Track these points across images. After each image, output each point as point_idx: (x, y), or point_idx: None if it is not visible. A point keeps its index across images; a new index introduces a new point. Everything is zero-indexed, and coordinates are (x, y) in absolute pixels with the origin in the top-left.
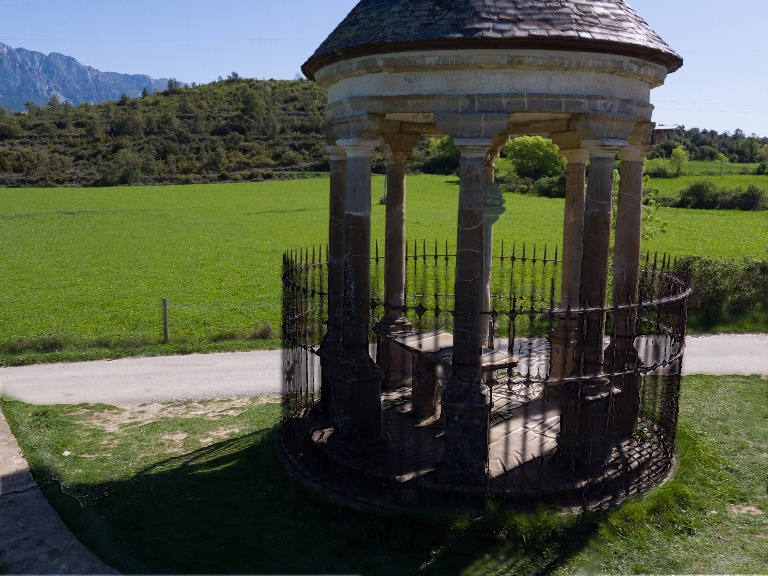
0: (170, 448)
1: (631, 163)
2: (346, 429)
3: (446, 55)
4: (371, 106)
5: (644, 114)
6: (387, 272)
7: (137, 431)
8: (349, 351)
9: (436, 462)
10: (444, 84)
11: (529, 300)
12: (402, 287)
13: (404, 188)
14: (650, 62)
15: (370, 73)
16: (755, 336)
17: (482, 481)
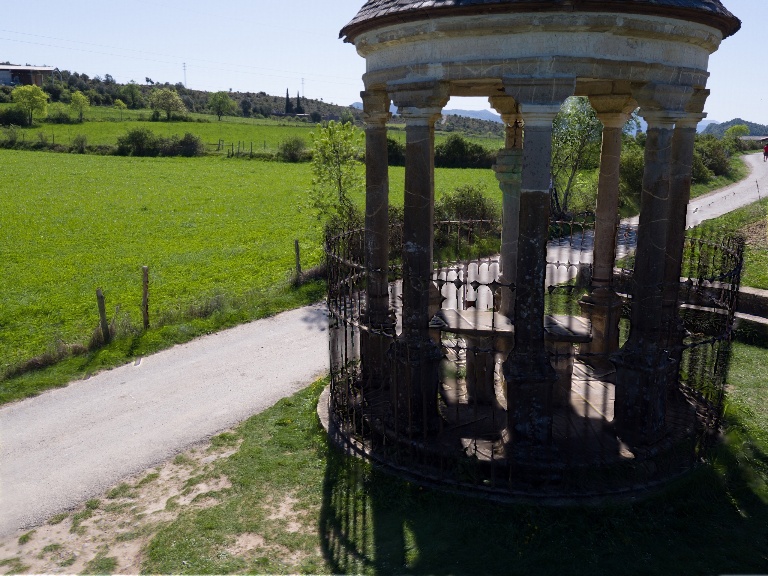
0: (283, 559)
1: (619, 130)
2: (543, 431)
3: (682, 25)
4: (587, 69)
5: None
6: (377, 255)
7: (175, 567)
8: (538, 346)
9: (605, 431)
10: (661, 54)
11: (437, 263)
12: None
13: None
14: None
15: (590, 31)
16: (459, 266)
17: (671, 430)
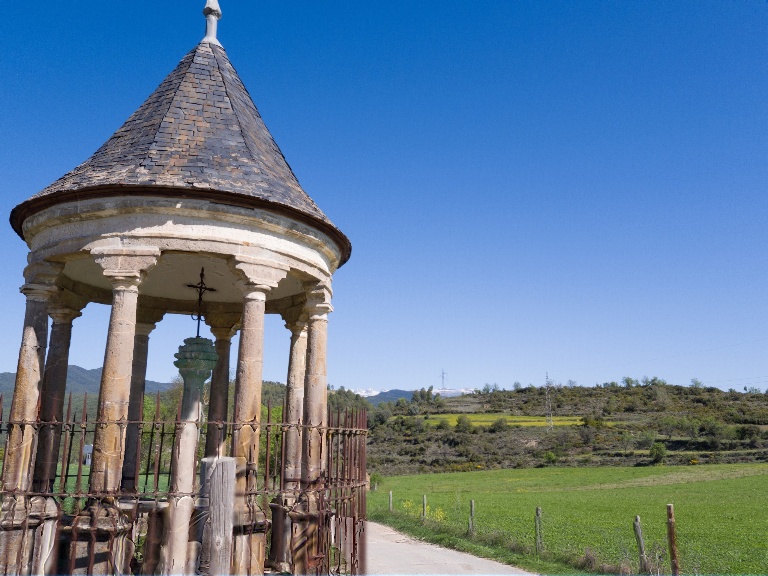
0: None
1: None
2: None
3: None
4: None
5: (57, 252)
6: None
7: None
8: None
9: None
10: None
11: None
12: (288, 457)
13: (295, 357)
14: (38, 213)
15: None
16: None
17: None
